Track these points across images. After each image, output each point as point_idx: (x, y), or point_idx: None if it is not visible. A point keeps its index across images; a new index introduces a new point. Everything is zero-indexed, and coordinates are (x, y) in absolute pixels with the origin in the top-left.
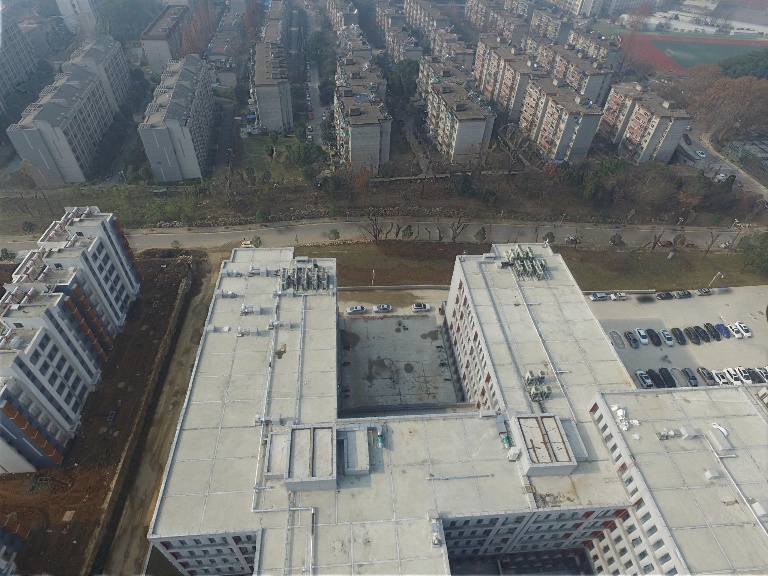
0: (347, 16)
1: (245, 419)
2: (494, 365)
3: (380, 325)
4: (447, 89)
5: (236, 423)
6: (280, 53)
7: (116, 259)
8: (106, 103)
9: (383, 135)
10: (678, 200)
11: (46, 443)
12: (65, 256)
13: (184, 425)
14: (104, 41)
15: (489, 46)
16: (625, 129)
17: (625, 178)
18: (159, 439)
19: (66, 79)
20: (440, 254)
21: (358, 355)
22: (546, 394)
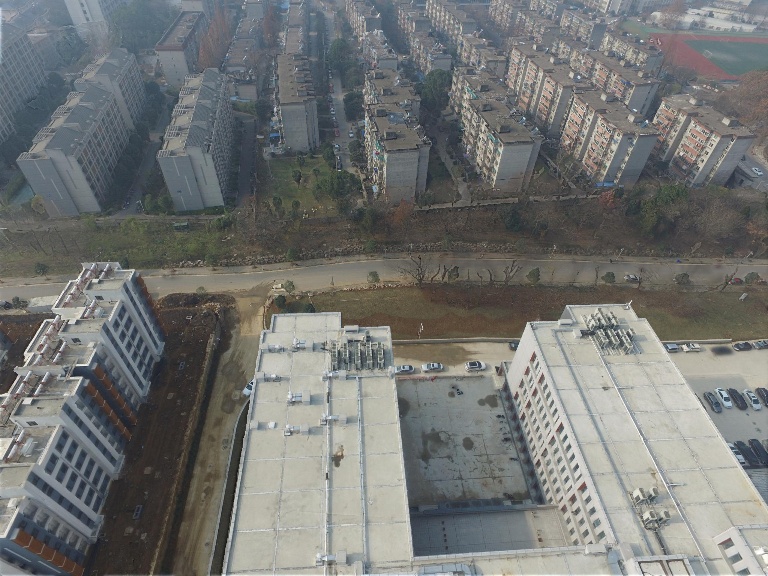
0: (369, 20)
1: (303, 556)
2: (592, 475)
3: (431, 388)
4: (487, 107)
5: (293, 562)
6: (304, 66)
7: (139, 321)
8: (121, 122)
9: (421, 160)
10: (747, 232)
11: (65, 561)
12: (84, 329)
13: (231, 566)
14: (118, 54)
15: (525, 54)
16: (677, 146)
17: (688, 207)
18: (191, 538)
19: (79, 99)
20: (491, 300)
21: (410, 427)
22: (663, 520)
